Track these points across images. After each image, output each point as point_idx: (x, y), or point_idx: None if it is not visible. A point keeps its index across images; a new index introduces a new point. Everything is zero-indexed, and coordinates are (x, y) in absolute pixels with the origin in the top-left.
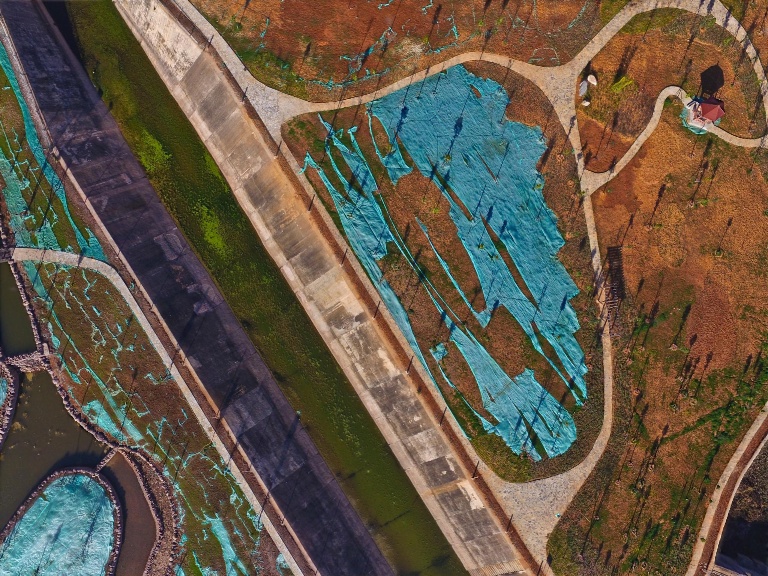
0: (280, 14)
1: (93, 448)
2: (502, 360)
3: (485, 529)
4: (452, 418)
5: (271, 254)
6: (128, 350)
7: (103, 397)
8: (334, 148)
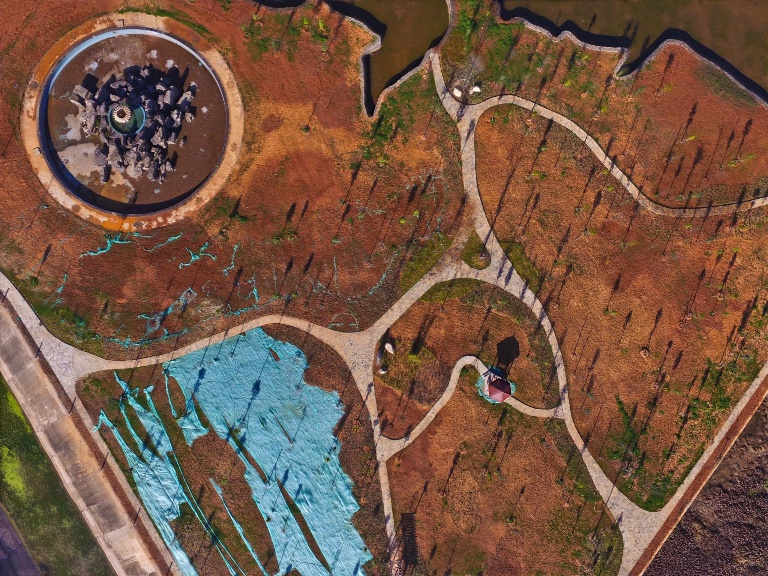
0: (78, 270)
1: None
2: None
3: None
4: None
5: (72, 497)
6: None
7: None
8: (129, 407)
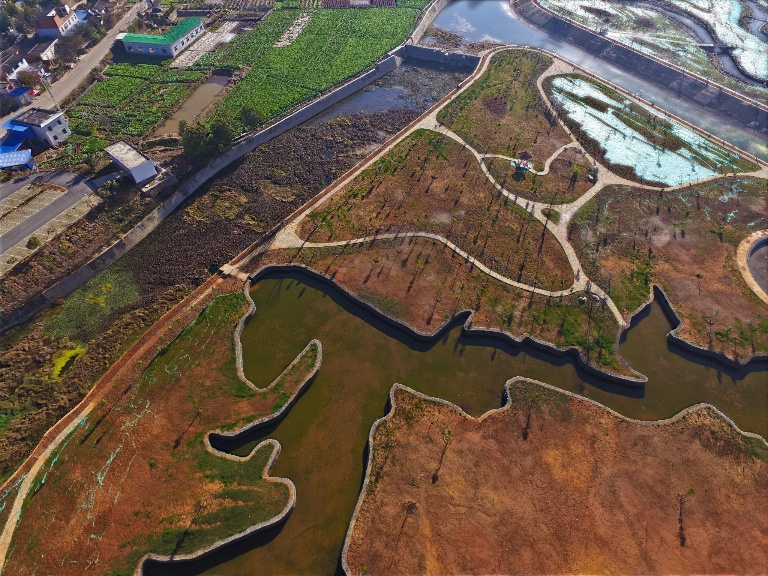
0: None
1: None
2: None
3: None
4: None
5: None
6: None
7: None
8: None
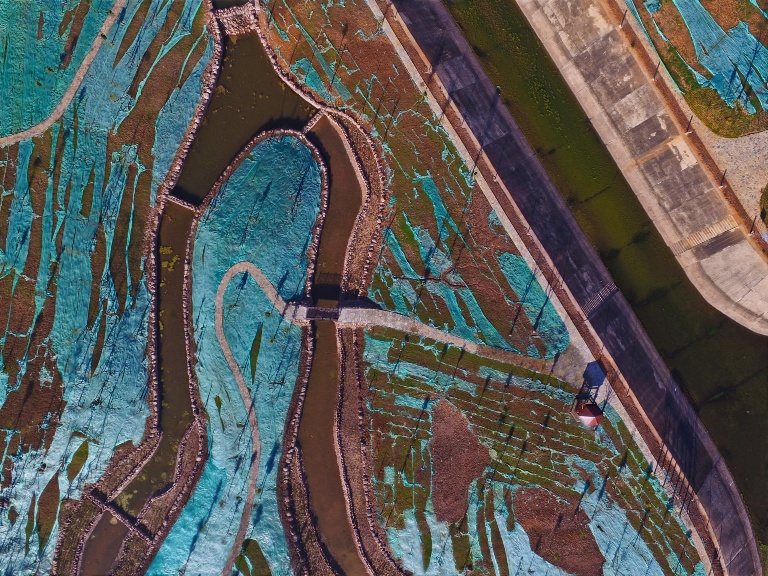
0: None
1: (297, 113)
2: (717, 12)
3: (696, 189)
4: (665, 73)
5: None
6: (339, 5)
7: (312, 54)
8: None
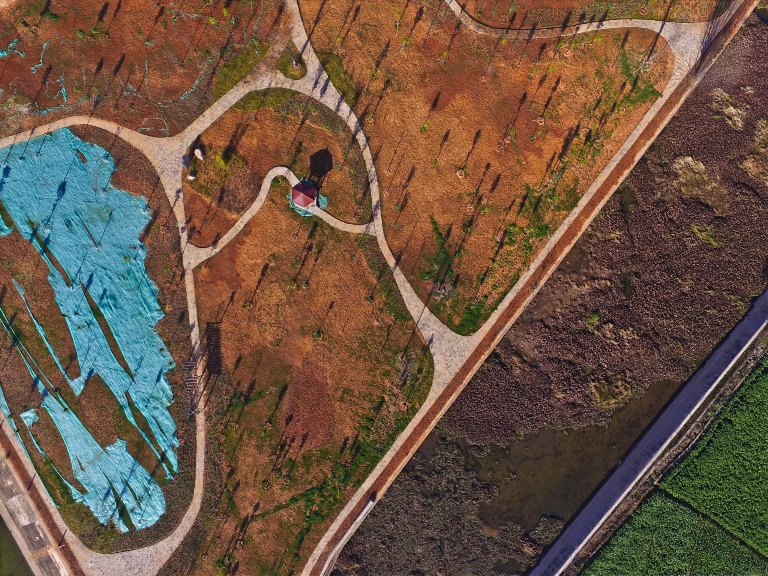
0: None
1: None
2: (94, 429)
3: None
4: (41, 485)
5: None
6: None
7: None
8: None
